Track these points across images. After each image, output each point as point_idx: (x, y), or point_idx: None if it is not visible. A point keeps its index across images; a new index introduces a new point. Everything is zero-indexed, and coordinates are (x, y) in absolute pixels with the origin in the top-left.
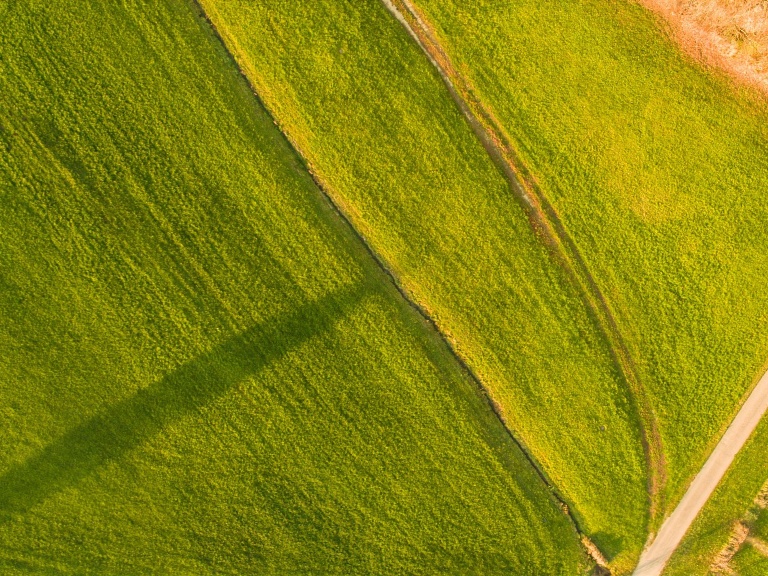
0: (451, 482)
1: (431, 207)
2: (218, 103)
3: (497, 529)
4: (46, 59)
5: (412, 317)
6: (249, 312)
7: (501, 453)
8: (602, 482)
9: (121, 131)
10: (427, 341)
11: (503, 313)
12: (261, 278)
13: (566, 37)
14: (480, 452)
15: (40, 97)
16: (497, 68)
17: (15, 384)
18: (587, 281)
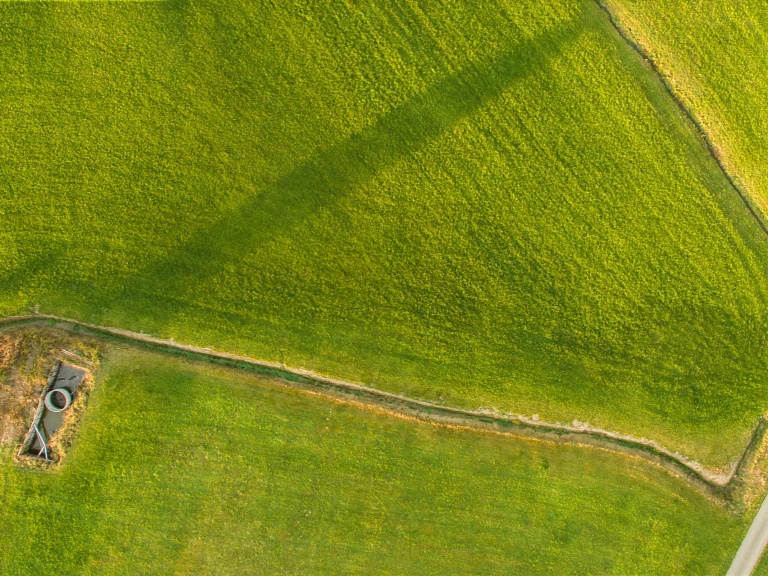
0: (670, 231)
1: None
2: None
3: (717, 281)
4: None
5: (630, 56)
6: (464, 52)
7: (721, 200)
8: None
9: None
10: (646, 81)
11: (725, 50)
12: (477, 16)
13: None
14: (700, 198)
15: None
16: None
17: (229, 128)
18: None
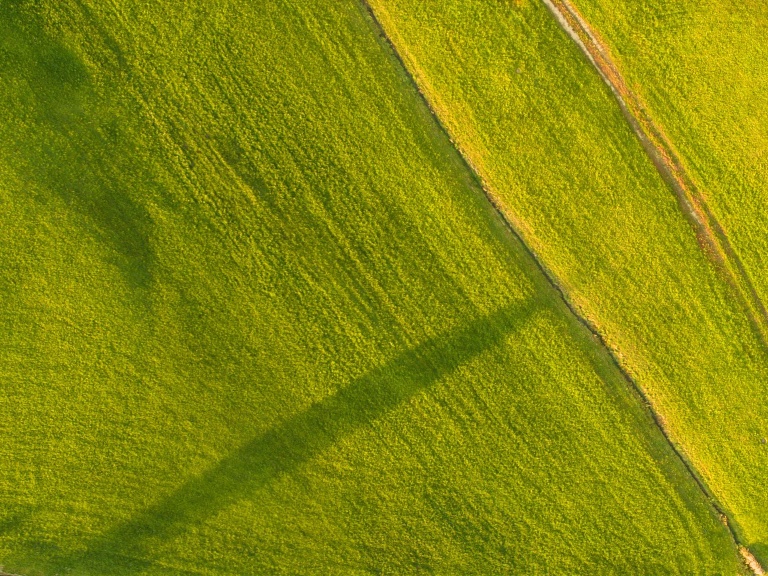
0: (615, 494)
1: (602, 224)
2: (397, 121)
3: (658, 540)
4: (230, 78)
5: (580, 332)
6: (422, 327)
7: (664, 465)
8: (761, 494)
9: (301, 149)
10: (595, 355)
11: (669, 328)
12: (434, 293)
13: (738, 58)
14: (644, 464)
15: (223, 115)
16: (669, 88)
17: (193, 398)
18: (751, 296)
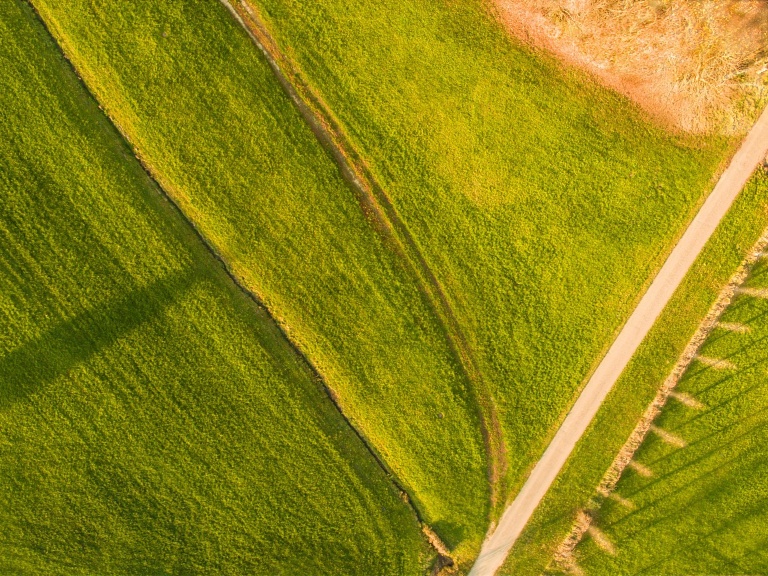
0: (287, 470)
1: (260, 192)
2: (41, 87)
3: (335, 518)
4: None
5: (244, 303)
6: (78, 299)
7: (338, 441)
8: (441, 470)
9: None
10: (260, 328)
11: (336, 299)
12: (89, 264)
13: (392, 19)
14: (316, 440)
15: None
16: (324, 51)
17: None
18: (421, 267)
